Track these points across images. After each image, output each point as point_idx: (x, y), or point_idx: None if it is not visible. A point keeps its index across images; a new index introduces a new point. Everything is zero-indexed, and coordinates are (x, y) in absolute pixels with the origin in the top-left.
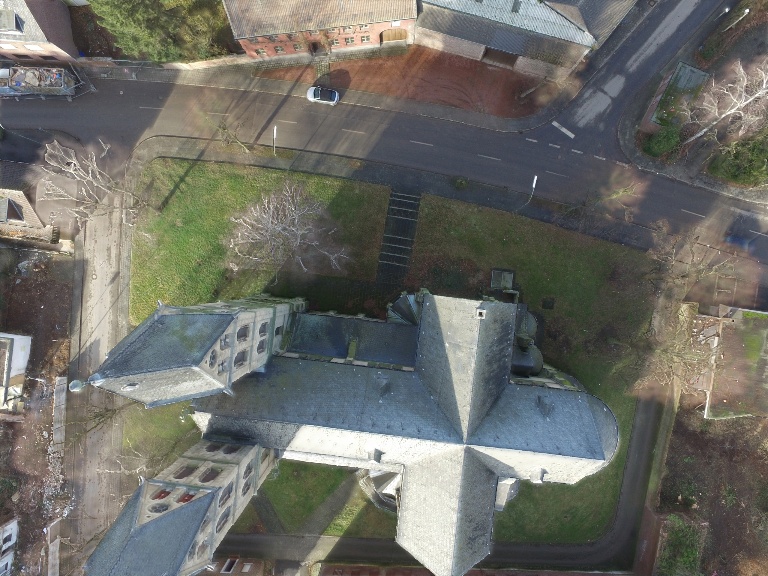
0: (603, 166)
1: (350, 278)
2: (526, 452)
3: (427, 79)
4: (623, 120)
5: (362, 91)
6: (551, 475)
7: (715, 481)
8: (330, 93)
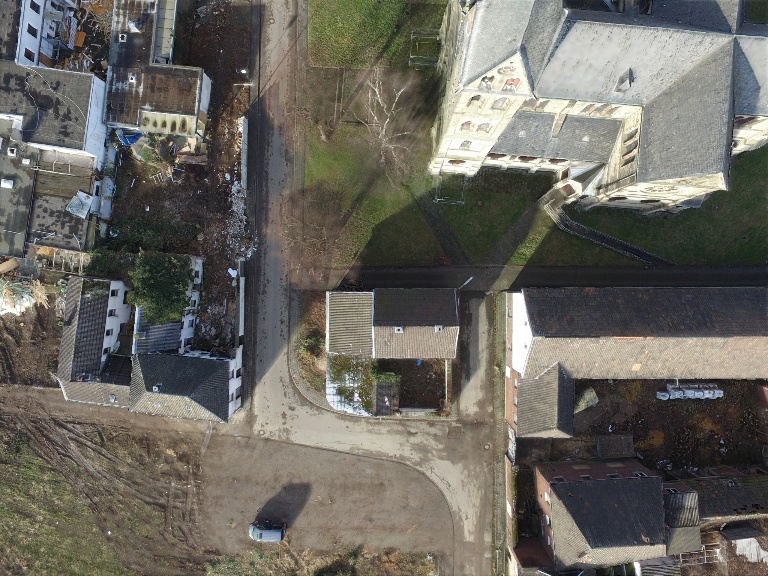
0: None
1: None
2: None
3: None
4: None
5: None
6: None
7: None
8: None
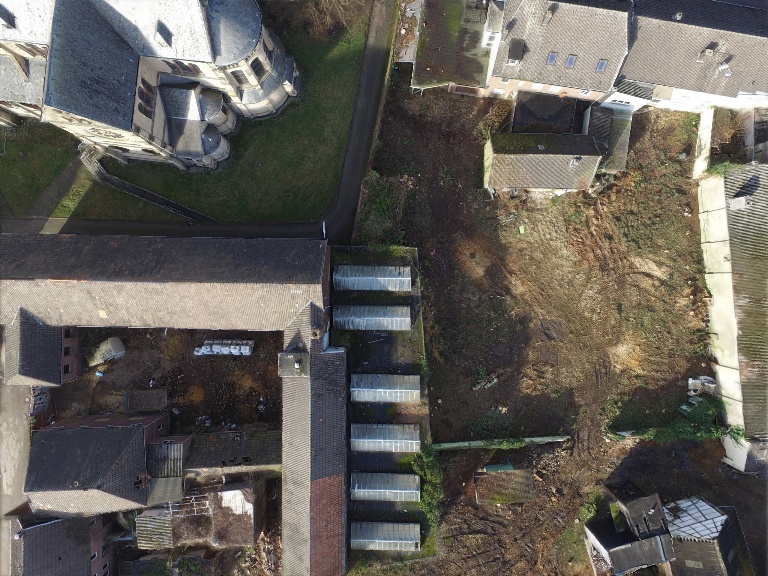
0: None
1: None
2: None
3: None
4: None
5: None
6: (179, 41)
7: (433, 163)
8: None
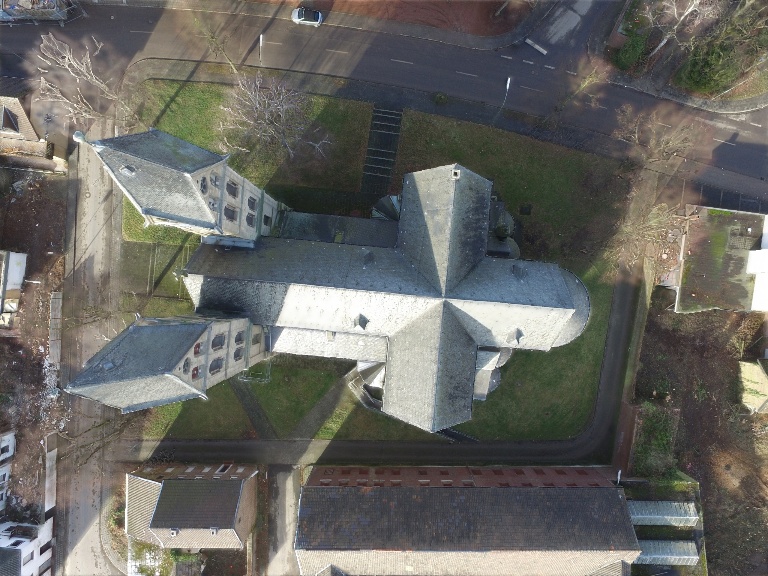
0: (574, 80)
1: (336, 189)
2: (501, 304)
3: (406, 0)
4: (592, 37)
5: (344, 13)
6: (527, 339)
7: (687, 377)
8: (314, 13)
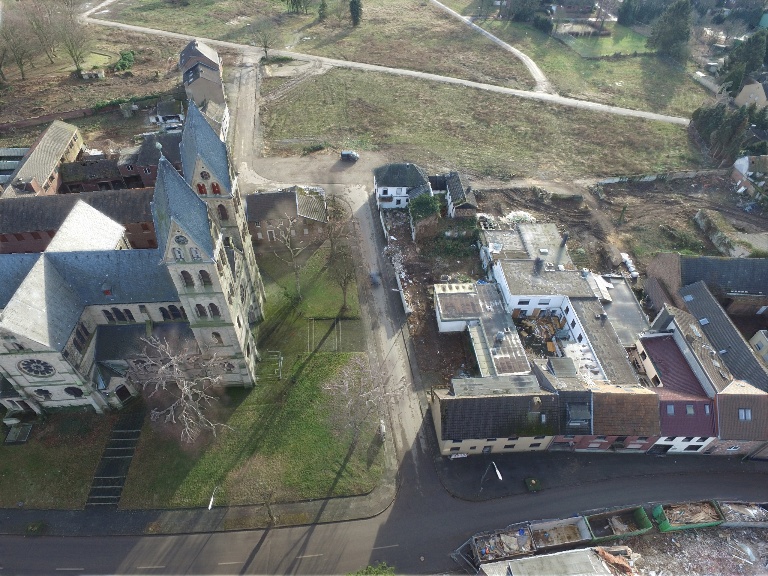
0: None
1: None
2: None
3: None
4: None
5: None
6: None
7: None
8: None
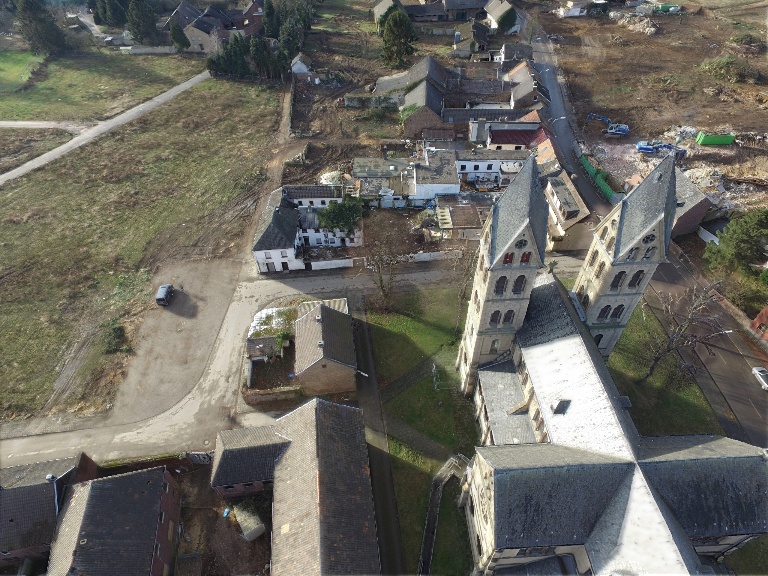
0: None
1: None
2: (666, 529)
3: None
4: None
5: None
6: None
7: None
8: None
